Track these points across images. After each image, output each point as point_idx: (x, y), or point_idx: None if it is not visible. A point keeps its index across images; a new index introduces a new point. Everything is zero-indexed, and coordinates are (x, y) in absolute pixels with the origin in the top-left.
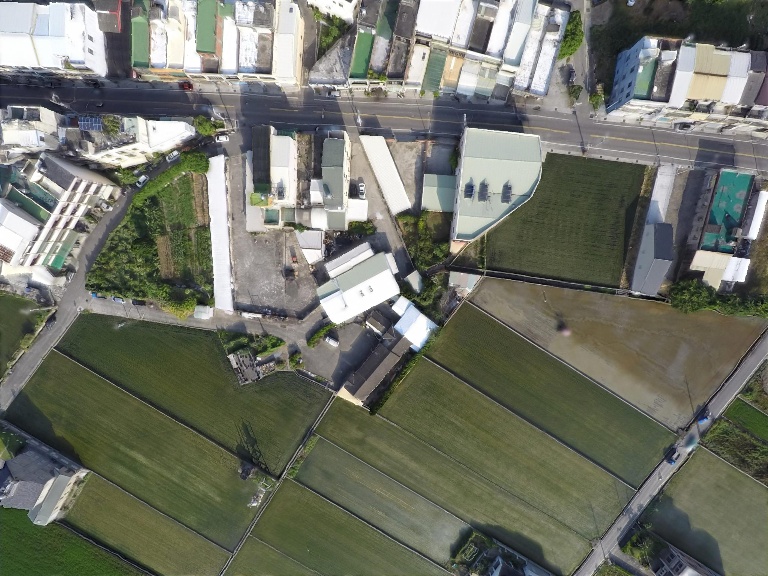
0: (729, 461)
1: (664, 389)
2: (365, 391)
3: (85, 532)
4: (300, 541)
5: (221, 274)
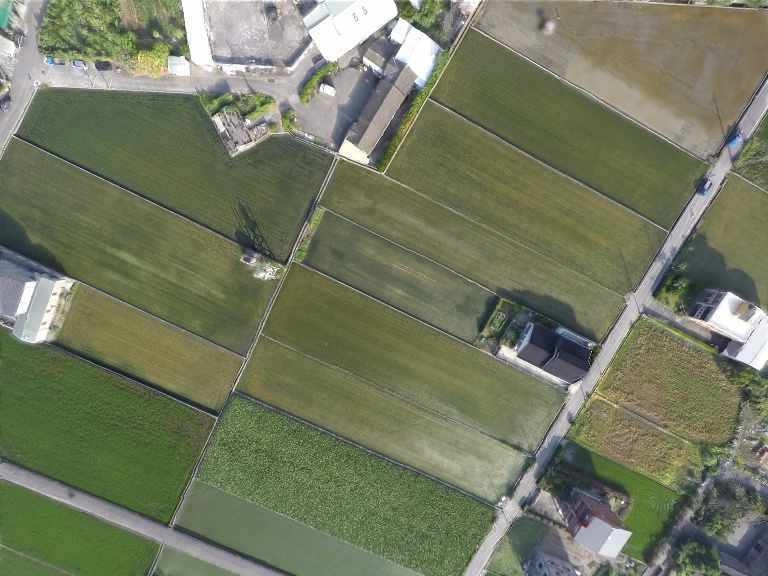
0: (763, 187)
1: (692, 111)
2: (370, 140)
3: (81, 354)
4: (317, 334)
5: (193, 14)
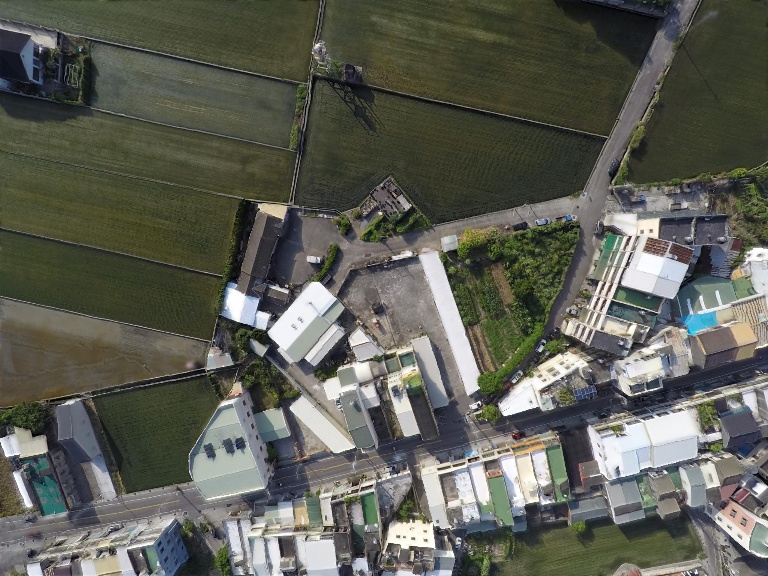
0: None
1: (3, 326)
2: (260, 224)
3: None
4: (261, 1)
5: (441, 289)
